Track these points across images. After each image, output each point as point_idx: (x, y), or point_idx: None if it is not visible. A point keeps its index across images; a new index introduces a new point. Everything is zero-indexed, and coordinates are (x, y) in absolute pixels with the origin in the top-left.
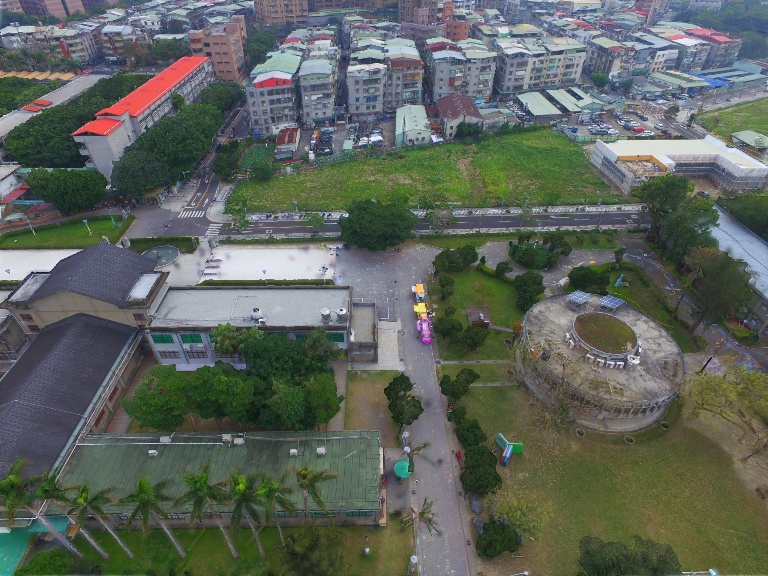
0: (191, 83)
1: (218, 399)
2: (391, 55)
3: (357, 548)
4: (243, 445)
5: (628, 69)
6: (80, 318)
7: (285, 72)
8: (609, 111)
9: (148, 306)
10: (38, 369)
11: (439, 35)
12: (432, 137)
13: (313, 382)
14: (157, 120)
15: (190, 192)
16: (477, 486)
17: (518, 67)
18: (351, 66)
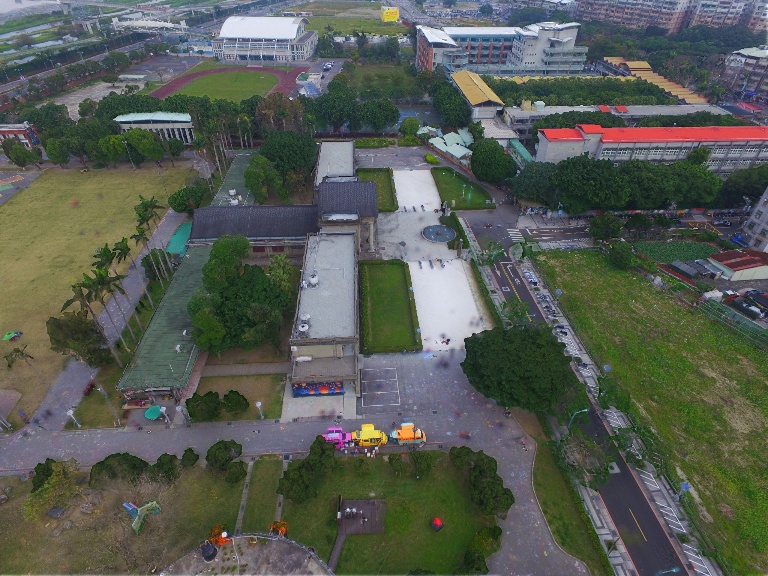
0: (764, 151)
1: None
2: None
3: (115, 392)
4: None
5: None
6: None
7: None
8: None
9: (319, 225)
10: None
11: None
12: None
13: (206, 312)
14: (640, 159)
15: (557, 225)
16: None
17: None
18: None
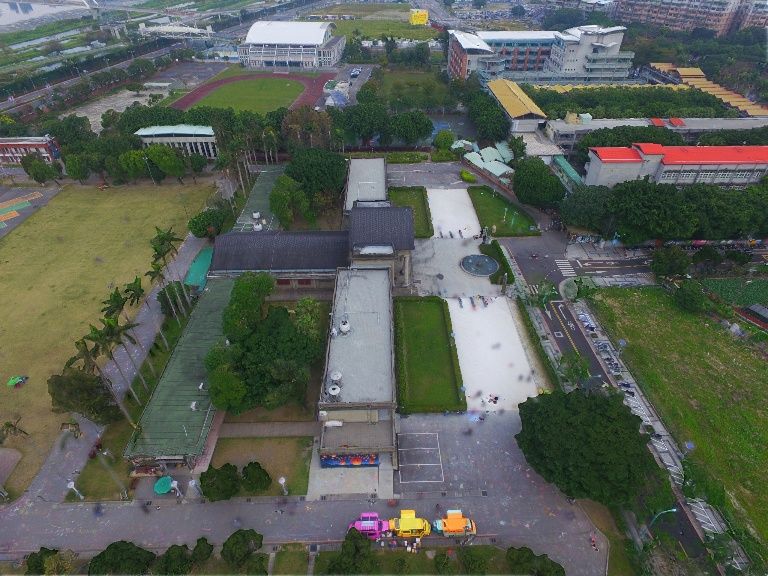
0: None
1: None
2: None
3: None
4: None
5: None
6: None
7: None
8: None
9: (351, 259)
10: (301, 236)
11: None
12: None
13: (224, 369)
14: (705, 182)
15: (611, 256)
16: None
17: None
18: None
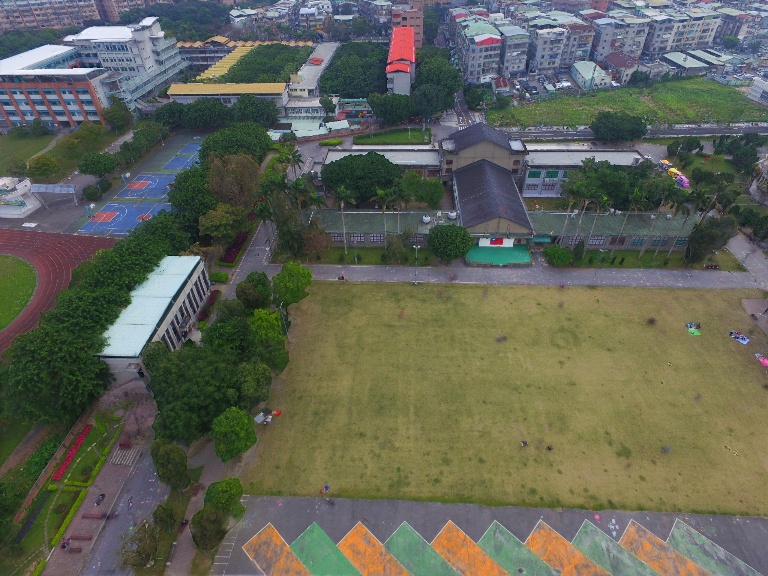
0: None
1: (620, 181)
2: (563, 22)
3: None
4: (620, 215)
5: (753, 34)
6: (485, 161)
7: (494, 34)
8: (748, 64)
9: (528, 153)
10: (488, 179)
11: (587, 8)
12: (612, 82)
13: None
14: None
15: (454, 116)
16: (767, 231)
17: (665, 31)
18: (539, 30)
